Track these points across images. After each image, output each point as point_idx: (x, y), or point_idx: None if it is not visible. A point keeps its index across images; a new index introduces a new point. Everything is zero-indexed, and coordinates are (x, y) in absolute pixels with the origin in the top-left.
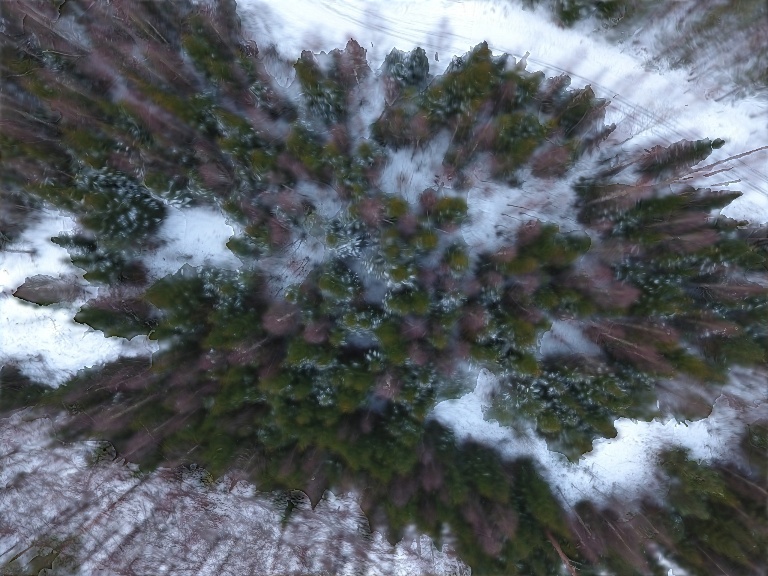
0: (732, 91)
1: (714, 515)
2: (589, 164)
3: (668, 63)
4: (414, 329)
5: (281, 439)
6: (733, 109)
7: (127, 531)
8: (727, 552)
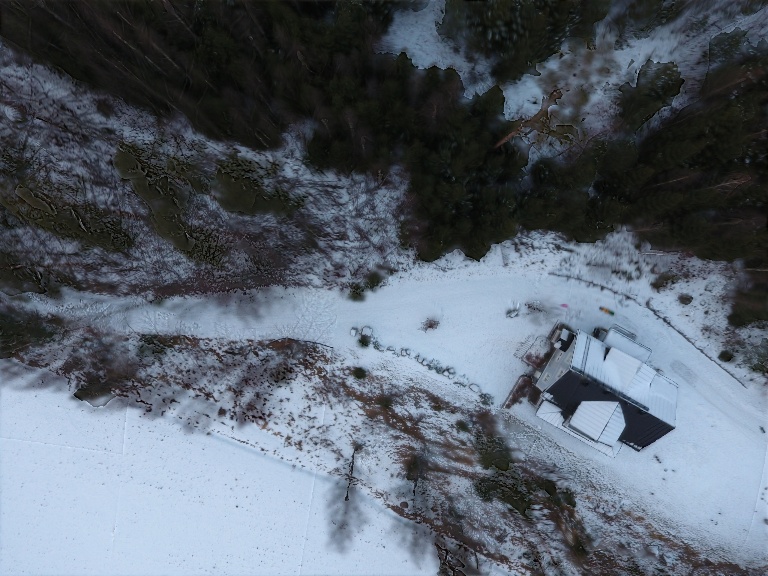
0: None
1: (669, 131)
2: None
3: None
4: None
5: (219, 8)
6: None
7: None
8: (680, 153)
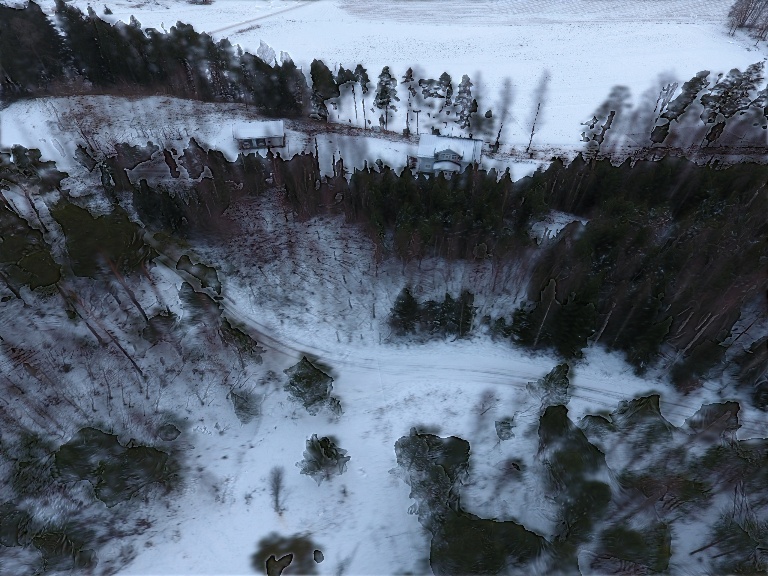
0: None
1: None
2: (725, 373)
3: None
4: (767, 220)
5: None
6: None
7: None
8: None
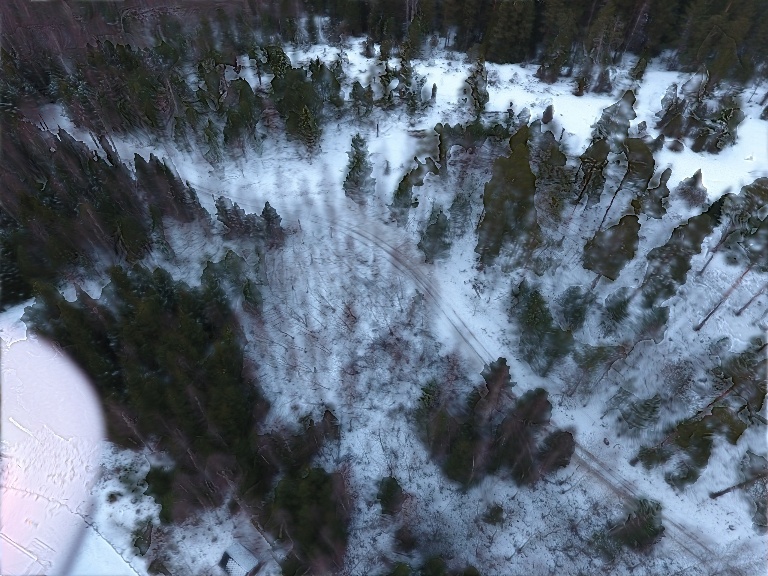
0: (163, 145)
1: None
2: None
3: (146, 144)
4: None
5: None
6: (175, 158)
7: None
8: None
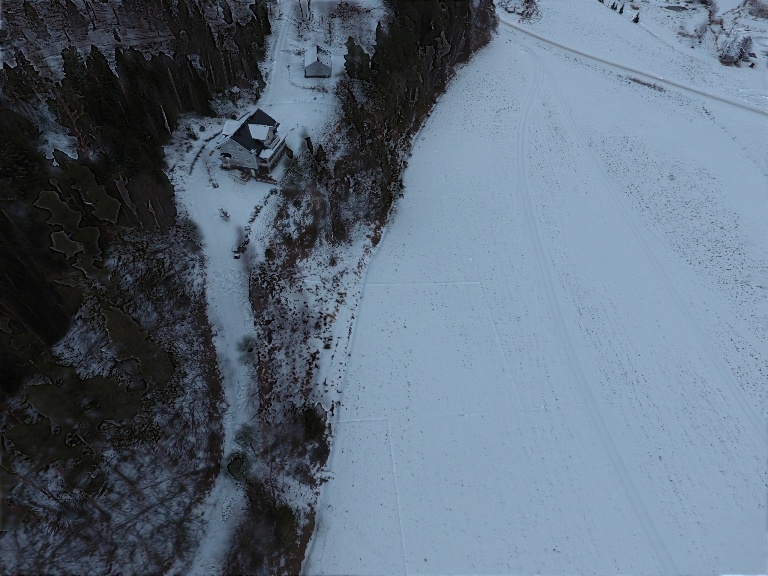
0: None
1: (97, 116)
2: None
3: None
4: None
5: None
6: None
7: (131, 471)
8: (107, 106)
